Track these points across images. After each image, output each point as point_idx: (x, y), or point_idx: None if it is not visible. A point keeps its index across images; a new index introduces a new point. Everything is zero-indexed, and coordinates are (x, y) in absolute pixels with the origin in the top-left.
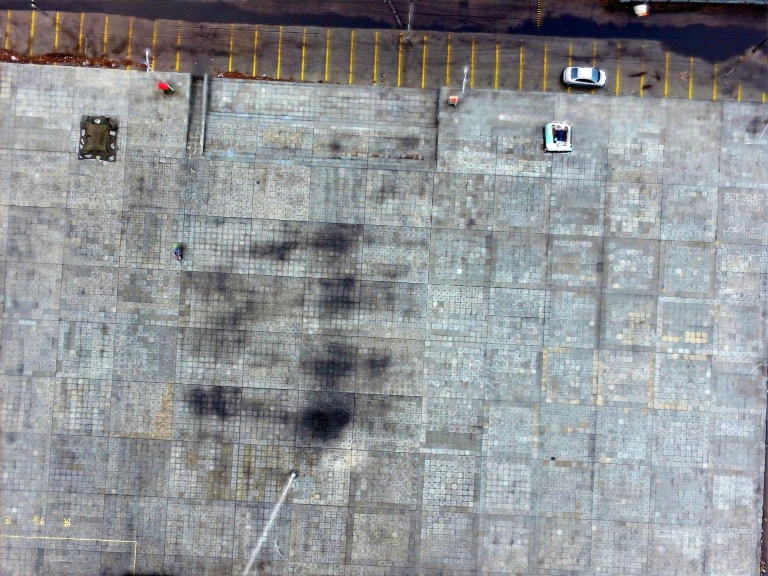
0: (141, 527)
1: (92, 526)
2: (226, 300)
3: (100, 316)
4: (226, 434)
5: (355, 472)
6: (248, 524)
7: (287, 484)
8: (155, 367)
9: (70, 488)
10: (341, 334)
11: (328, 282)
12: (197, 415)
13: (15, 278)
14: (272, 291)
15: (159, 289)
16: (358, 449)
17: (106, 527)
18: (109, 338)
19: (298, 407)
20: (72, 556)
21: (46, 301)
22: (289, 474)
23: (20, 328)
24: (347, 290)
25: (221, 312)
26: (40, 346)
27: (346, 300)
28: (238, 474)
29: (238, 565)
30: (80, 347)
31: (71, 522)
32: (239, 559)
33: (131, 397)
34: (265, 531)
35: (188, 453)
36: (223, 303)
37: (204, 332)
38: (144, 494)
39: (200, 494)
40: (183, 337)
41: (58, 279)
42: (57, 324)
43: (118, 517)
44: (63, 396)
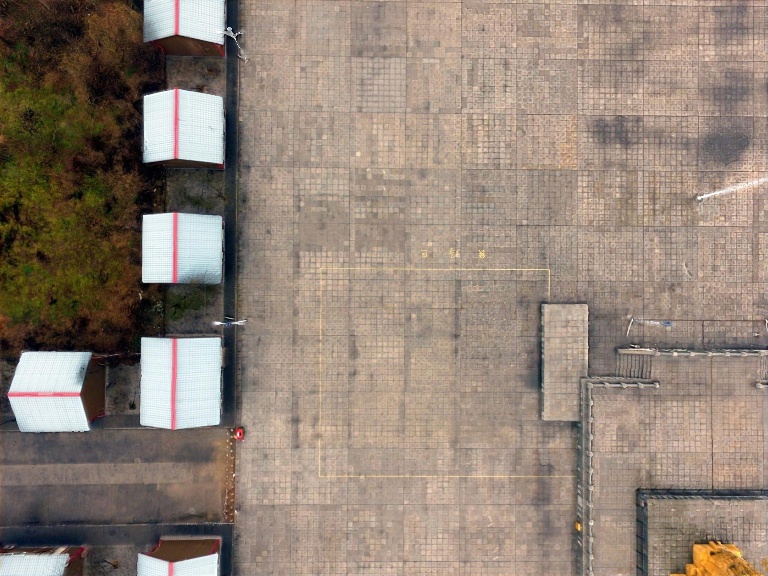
0: (553, 255)
1: (506, 256)
2: (623, 31)
3: (501, 52)
4: (630, 162)
5: (757, 193)
6: (656, 248)
7: (692, 208)
8: (558, 100)
9: (482, 221)
10: (737, 60)
11: (721, 9)
12: (601, 145)
13: (416, 18)
14: (667, 21)
15: (557, 23)
16: (759, 171)
17: (519, 257)
18: (511, 73)
19: (699, 133)
20: (489, 286)
21: (448, 39)
22: (693, 198)
23: (424, 67)
24: (741, 16)
25: (619, 43)
26: (444, 84)
27: (740, 26)
28: (644, 200)
29: (649, 288)
30: (483, 83)
31: (485, 253)
32: (650, 282)
33: (536, 130)
34: (673, 254)
35: (594, 182)
36: (620, 34)
37: (603, 64)
38: (554, 223)
39: (608, 221)
40: (583, 69)
41: (458, 17)
42: (460, 61)
43: (530, 247)
44: (470, 132)
